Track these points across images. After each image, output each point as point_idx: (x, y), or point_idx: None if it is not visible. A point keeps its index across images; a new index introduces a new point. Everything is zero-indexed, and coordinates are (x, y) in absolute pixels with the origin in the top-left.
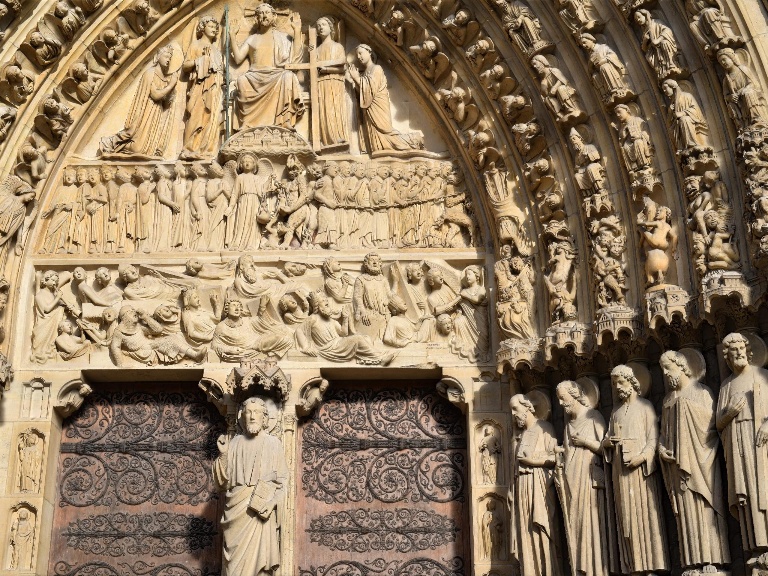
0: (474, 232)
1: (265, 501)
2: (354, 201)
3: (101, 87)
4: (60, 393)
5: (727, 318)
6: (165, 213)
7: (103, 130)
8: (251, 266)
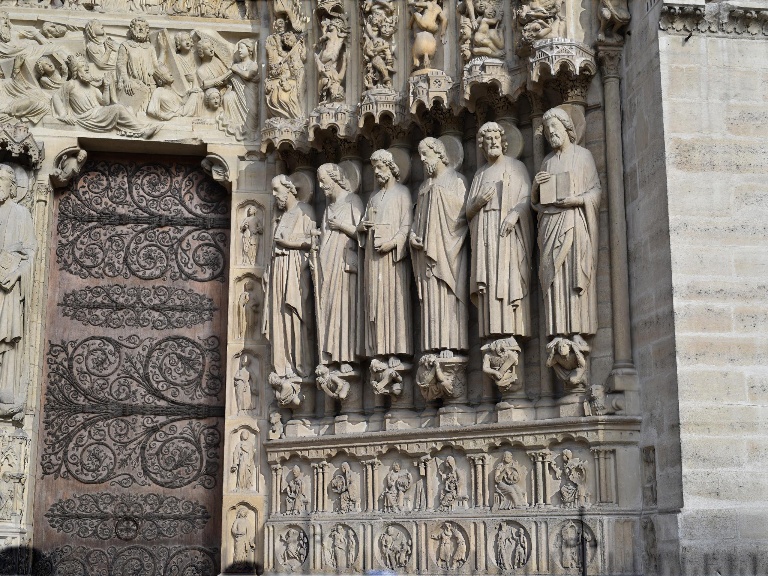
0: (250, 3)
1: (8, 272)
2: None
3: None
4: None
5: (489, 107)
6: None
7: None
8: (5, 23)
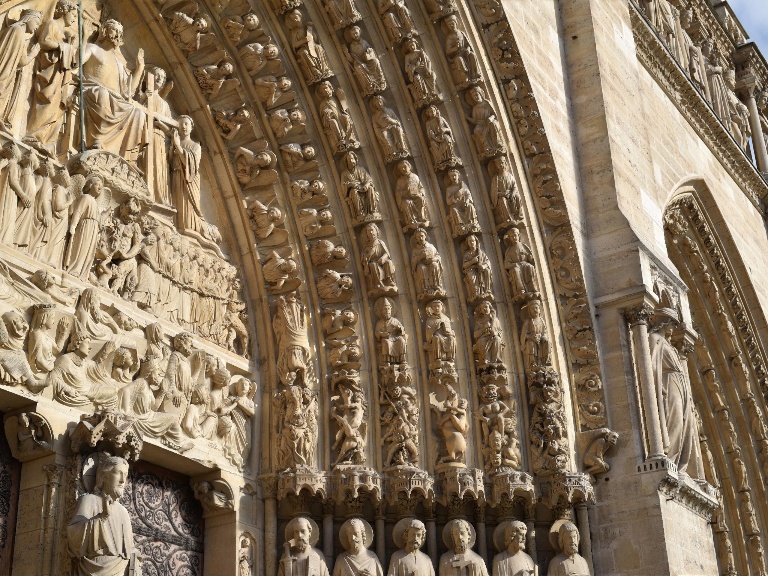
0: None
1: None
2: (170, 271)
3: None
4: None
5: None
6: (14, 201)
7: None
8: None
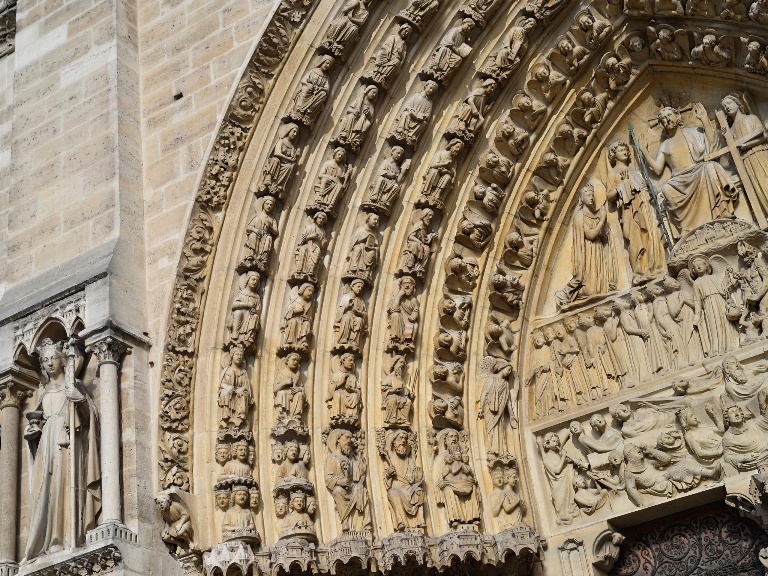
0: None
1: None
2: None
3: (539, 247)
4: (594, 548)
5: None
6: (636, 343)
7: (555, 285)
8: (737, 367)
